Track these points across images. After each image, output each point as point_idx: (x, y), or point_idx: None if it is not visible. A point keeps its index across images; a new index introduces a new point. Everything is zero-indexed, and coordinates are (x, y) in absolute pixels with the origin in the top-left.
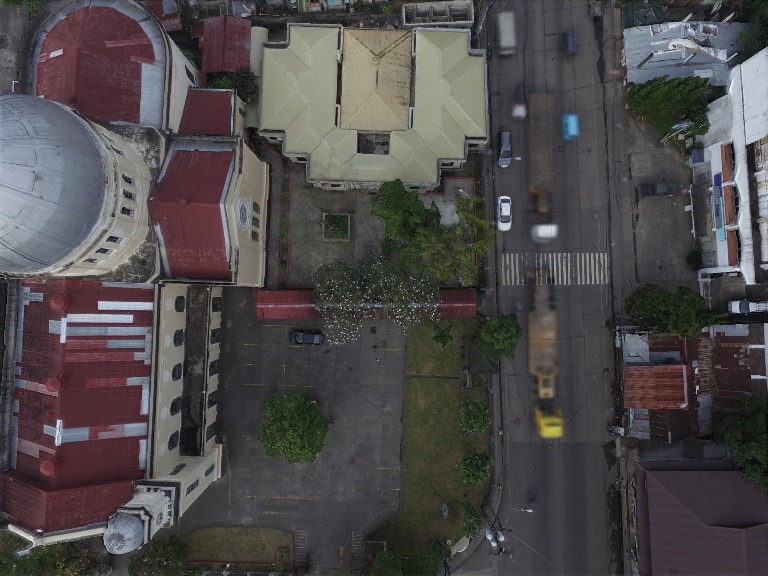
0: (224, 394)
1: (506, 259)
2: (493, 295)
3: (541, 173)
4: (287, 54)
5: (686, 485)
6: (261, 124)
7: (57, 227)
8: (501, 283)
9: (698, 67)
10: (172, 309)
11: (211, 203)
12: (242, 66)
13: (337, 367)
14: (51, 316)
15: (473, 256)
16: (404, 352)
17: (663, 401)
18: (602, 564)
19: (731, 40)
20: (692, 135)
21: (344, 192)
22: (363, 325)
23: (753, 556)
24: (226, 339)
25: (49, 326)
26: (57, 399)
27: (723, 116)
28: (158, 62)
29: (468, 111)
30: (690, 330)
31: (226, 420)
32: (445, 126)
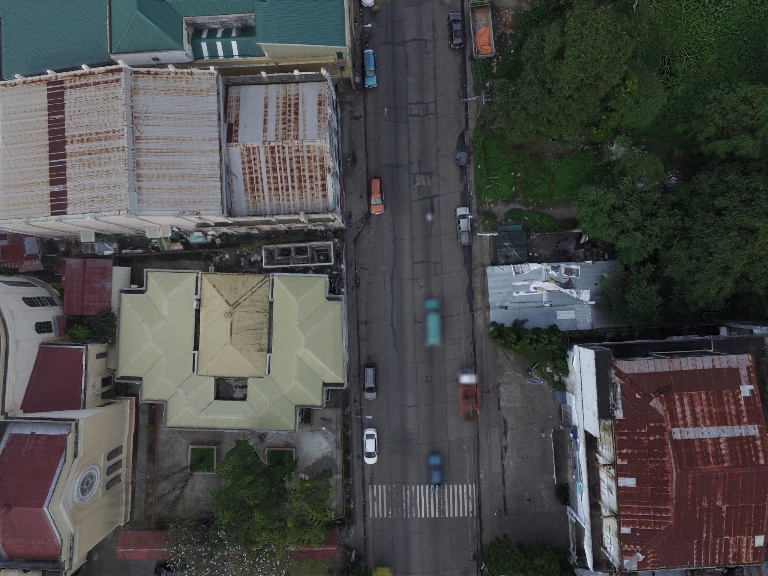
0: None
1: (374, 491)
2: (360, 527)
3: (409, 404)
4: (144, 301)
5: None
6: (118, 371)
7: None
8: (368, 515)
9: (560, 308)
10: (19, 575)
11: (35, 507)
12: (102, 307)
13: None
14: None
15: (341, 487)
16: None
17: None
18: None
19: (595, 279)
20: None
21: None
22: None
23: None
24: (93, 571)
25: None
26: None
27: None
28: None
29: (324, 360)
30: None
31: None
32: (300, 376)
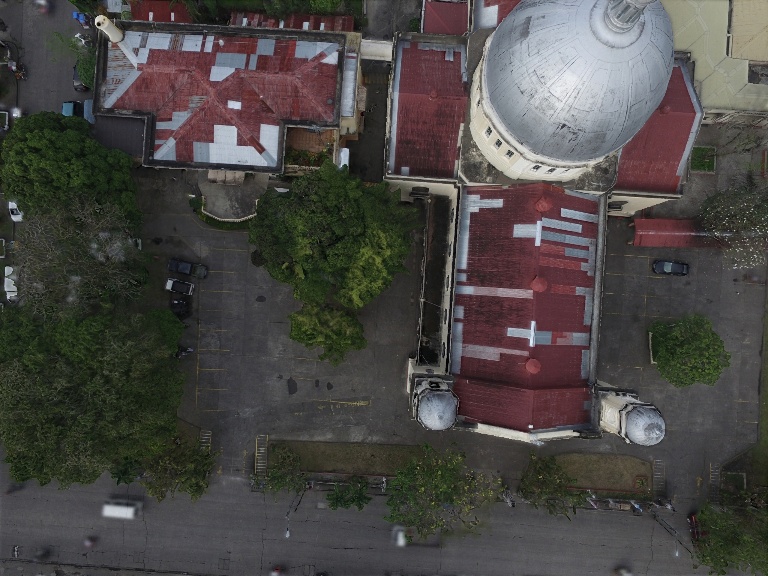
0: None
1: None
2: None
3: None
4: None
5: None
6: None
7: (653, 110)
8: None
9: None
10: None
11: (688, 112)
12: None
13: (698, 299)
14: (518, 220)
15: None
16: (764, 287)
17: None
18: None
19: None
20: None
21: (708, 126)
22: None
23: None
24: None
25: (514, 230)
26: (532, 301)
27: None
28: None
29: None
30: None
31: None
32: None
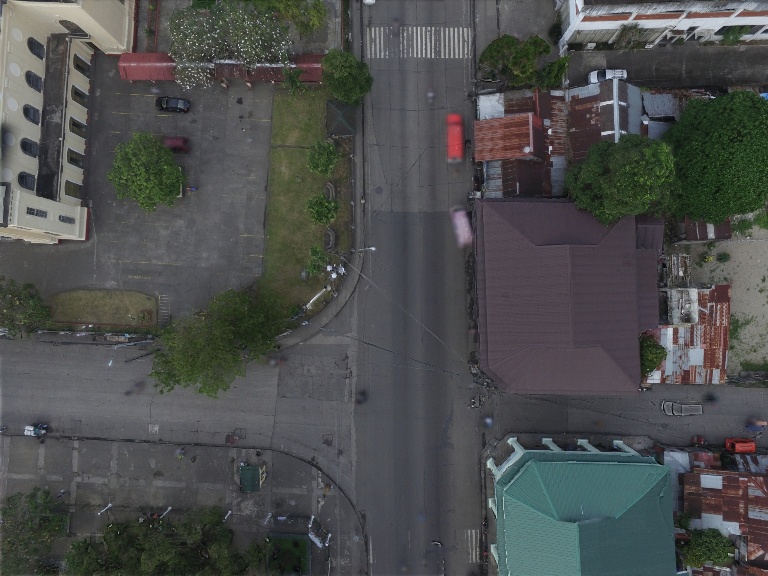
0: (91, 160)
1: (371, 33)
2: None
3: None
4: None
5: (520, 213)
6: None
7: None
8: (366, 56)
9: None
10: (23, 44)
11: None
12: None
13: (203, 136)
14: None
15: (339, 30)
16: (270, 123)
17: (510, 150)
18: (460, 330)
19: None
20: None
21: None
22: (230, 96)
23: (579, 273)
24: (95, 107)
25: None
26: None
27: None
28: None
29: None
30: (529, 66)
31: (93, 186)
32: None
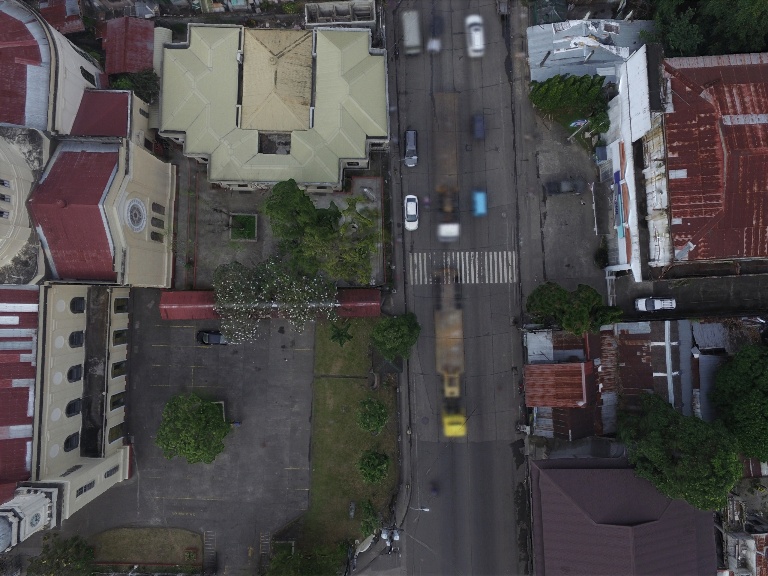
0: (132, 395)
1: (414, 258)
2: (401, 294)
3: (449, 172)
4: (187, 55)
5: (578, 483)
6: (162, 125)
7: None
8: (409, 282)
9: (600, 65)
10: (66, 310)
11: (90, 204)
12: (145, 67)
13: (245, 367)
14: None
15: (381, 255)
16: (312, 352)
17: (562, 399)
18: (511, 563)
19: (634, 38)
20: (597, 133)
21: (252, 192)
22: (271, 325)
23: (641, 554)
24: (134, 340)
25: None
26: None
27: (619, 114)
28: (45, 63)
29: (368, 110)
30: (583, 328)
31: (134, 421)
32: (345, 126)
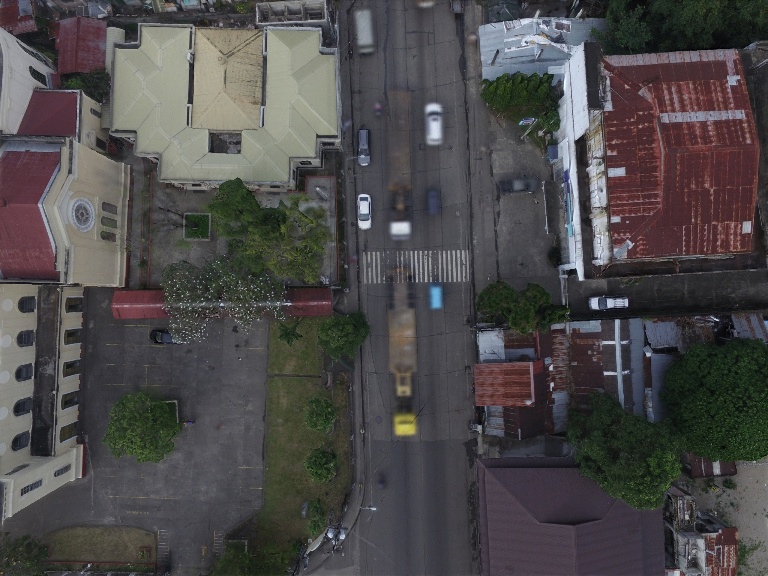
0: (86, 394)
1: (368, 257)
2: (355, 293)
3: (402, 171)
4: (138, 54)
5: (523, 482)
6: (112, 124)
7: None
8: (363, 281)
9: (552, 63)
10: (14, 310)
11: (29, 203)
12: (97, 67)
13: (199, 366)
14: None
15: (335, 254)
16: (266, 351)
17: (511, 398)
18: (464, 562)
19: (585, 36)
20: (550, 131)
21: (206, 192)
22: (225, 324)
23: (584, 553)
24: (88, 339)
25: None
26: None
27: None
28: None
29: (318, 109)
30: (529, 327)
31: (88, 420)
32: (294, 125)
